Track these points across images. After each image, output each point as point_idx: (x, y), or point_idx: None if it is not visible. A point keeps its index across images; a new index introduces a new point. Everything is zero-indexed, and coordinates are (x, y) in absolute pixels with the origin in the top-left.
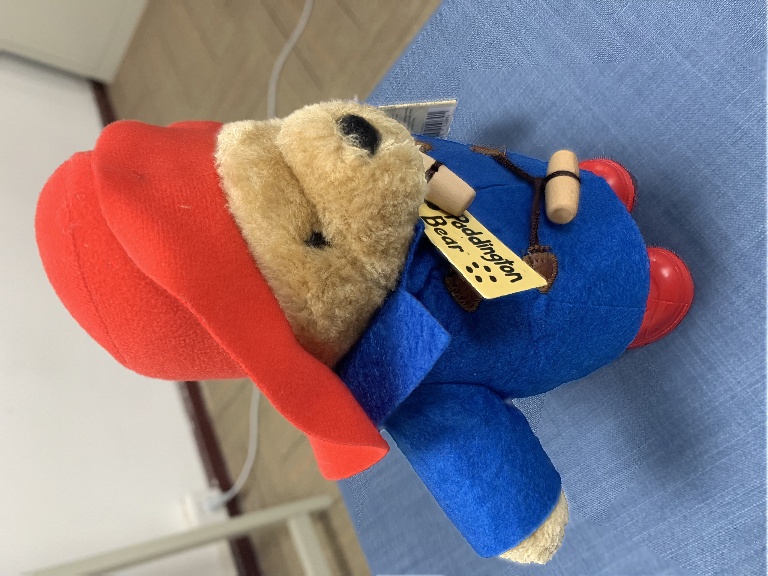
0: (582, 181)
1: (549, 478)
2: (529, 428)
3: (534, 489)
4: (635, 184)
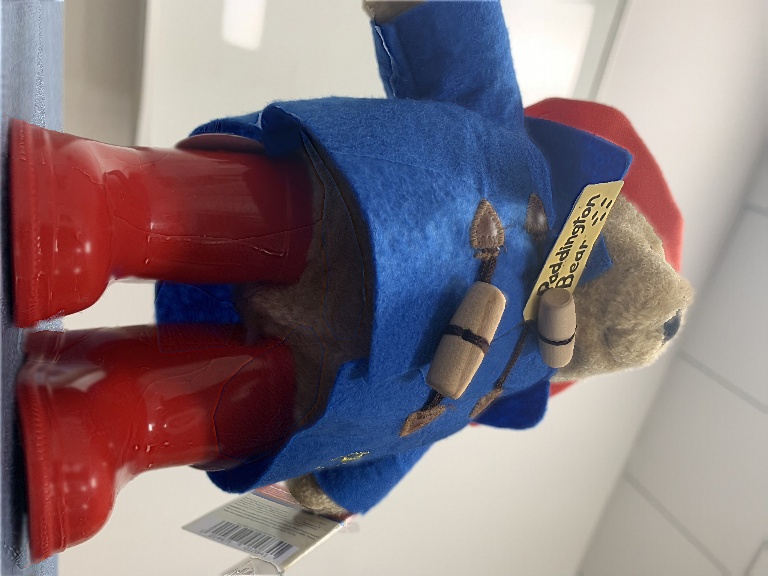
0: (399, 371)
1: (469, 7)
2: (462, 66)
3: (491, 8)
4: (19, 496)
